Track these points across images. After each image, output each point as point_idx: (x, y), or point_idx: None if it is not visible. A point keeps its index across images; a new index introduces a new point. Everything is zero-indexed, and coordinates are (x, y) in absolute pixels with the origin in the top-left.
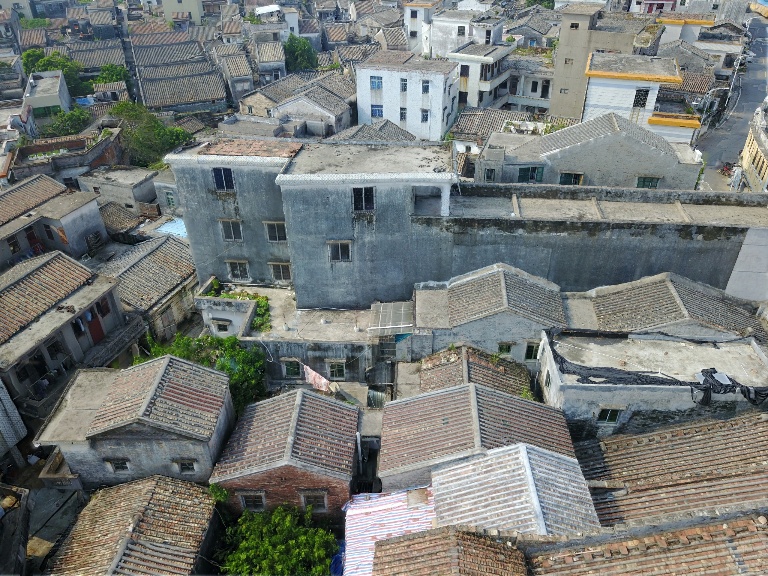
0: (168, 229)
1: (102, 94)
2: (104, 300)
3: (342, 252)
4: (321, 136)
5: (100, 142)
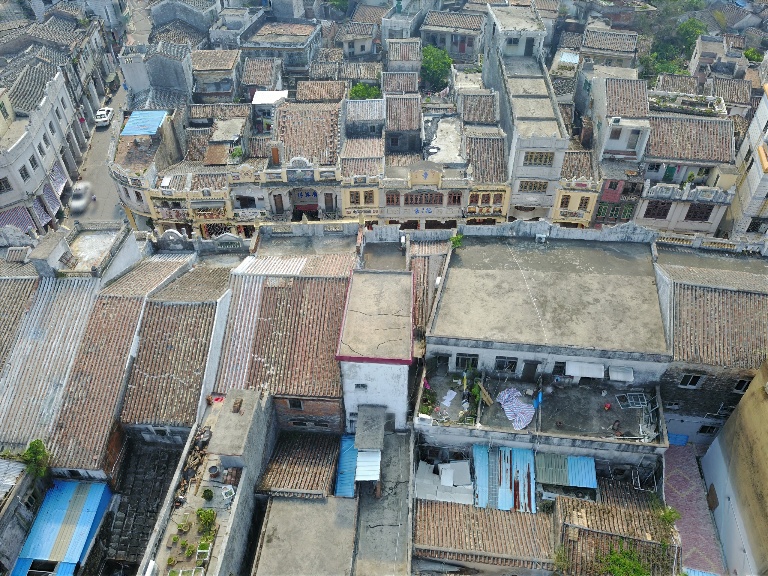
0: (565, 54)
1: (759, 3)
2: (472, 39)
3: (488, 54)
4: (732, 76)
5: (622, 6)
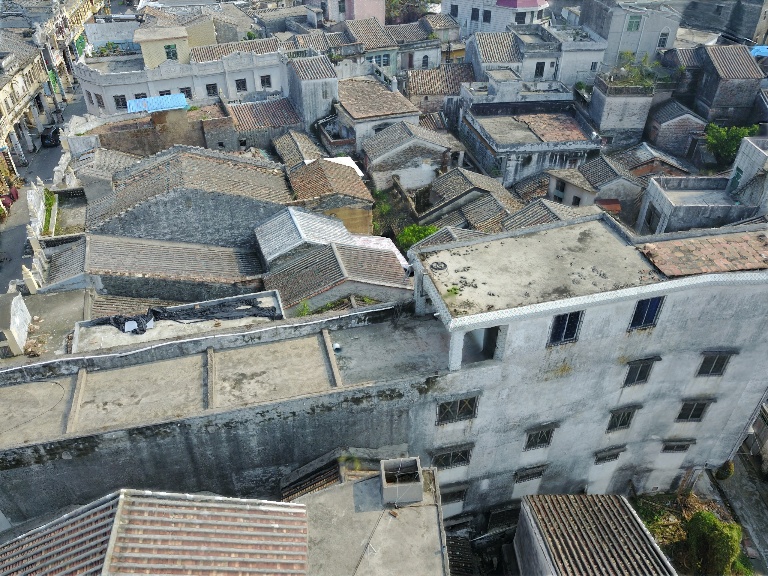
0: None
1: None
2: None
3: None
4: None
5: None
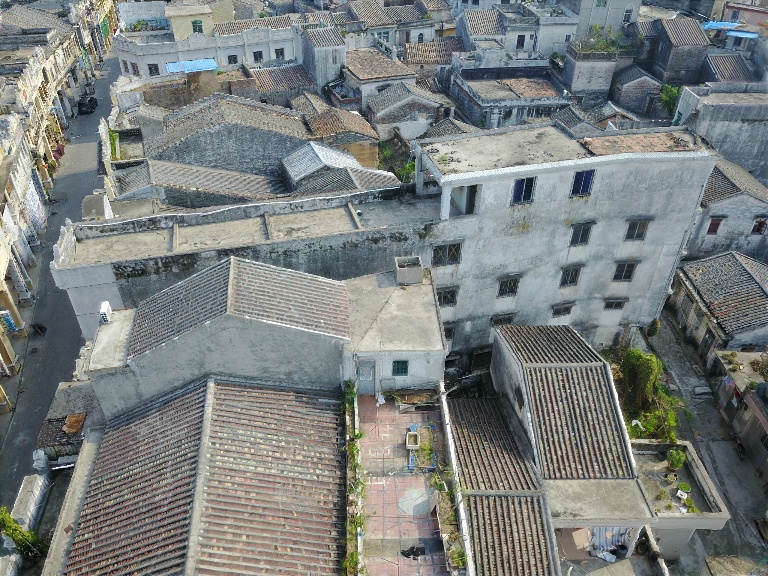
0: None
1: None
2: None
3: None
4: None
5: None
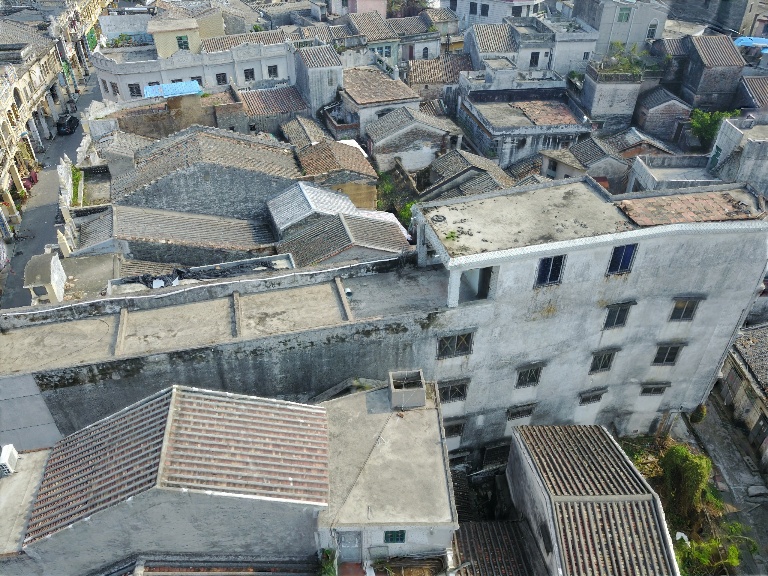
0: None
1: None
2: None
3: None
4: None
5: None
